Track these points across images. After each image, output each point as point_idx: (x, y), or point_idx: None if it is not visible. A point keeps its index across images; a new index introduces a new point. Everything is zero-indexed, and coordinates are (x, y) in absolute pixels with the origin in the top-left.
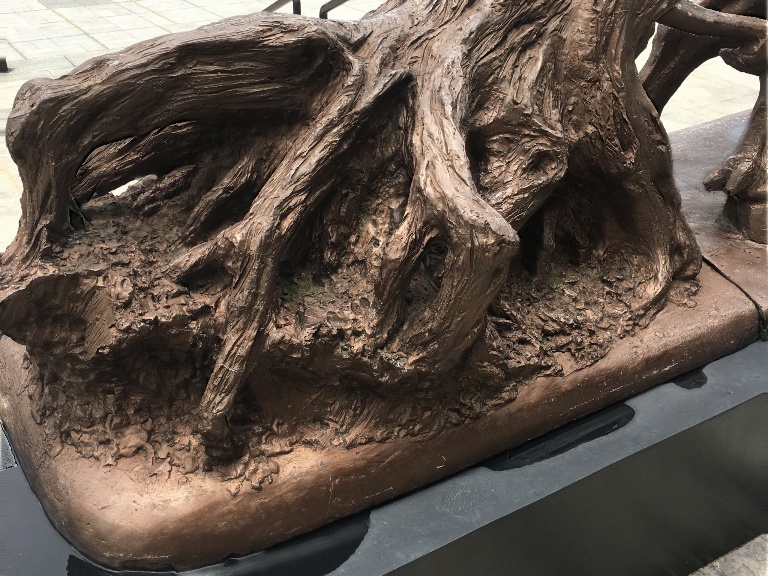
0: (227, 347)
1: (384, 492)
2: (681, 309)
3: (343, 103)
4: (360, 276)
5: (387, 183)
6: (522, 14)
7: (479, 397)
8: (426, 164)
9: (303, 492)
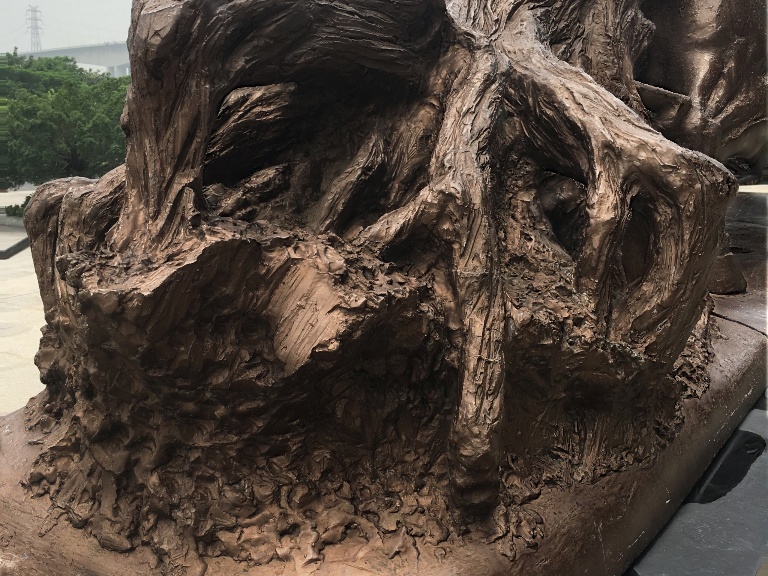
0: (476, 332)
1: (640, 538)
2: (721, 341)
3: (491, 60)
4: (530, 271)
5: (511, 175)
6: (552, 33)
7: (664, 415)
8: (600, 120)
9: (578, 545)
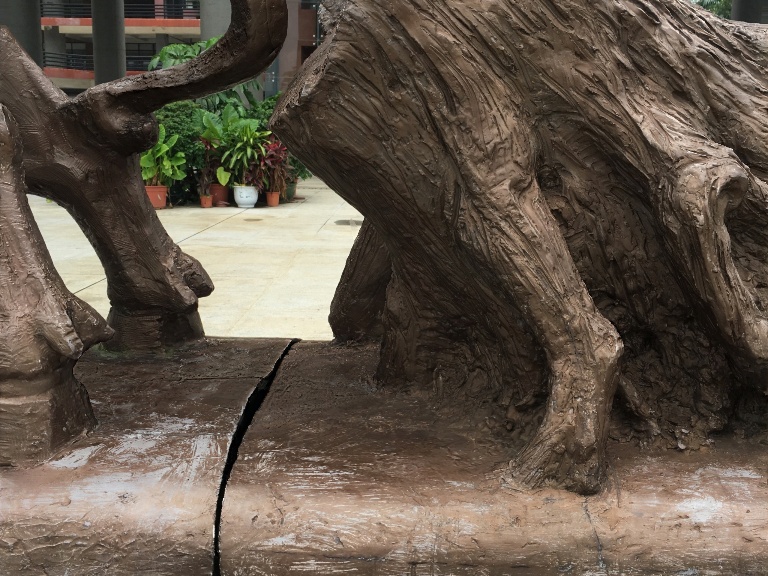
0: None
1: None
2: None
3: None
4: None
5: None
6: None
7: None
8: None
9: None
